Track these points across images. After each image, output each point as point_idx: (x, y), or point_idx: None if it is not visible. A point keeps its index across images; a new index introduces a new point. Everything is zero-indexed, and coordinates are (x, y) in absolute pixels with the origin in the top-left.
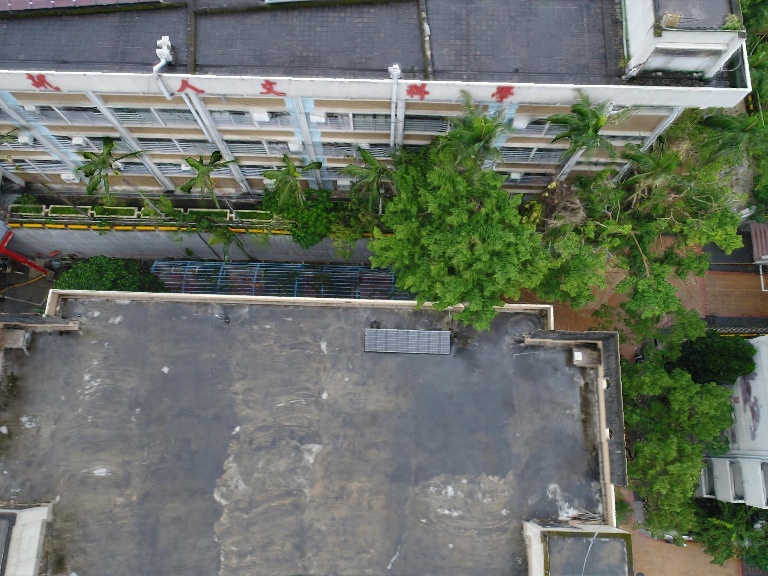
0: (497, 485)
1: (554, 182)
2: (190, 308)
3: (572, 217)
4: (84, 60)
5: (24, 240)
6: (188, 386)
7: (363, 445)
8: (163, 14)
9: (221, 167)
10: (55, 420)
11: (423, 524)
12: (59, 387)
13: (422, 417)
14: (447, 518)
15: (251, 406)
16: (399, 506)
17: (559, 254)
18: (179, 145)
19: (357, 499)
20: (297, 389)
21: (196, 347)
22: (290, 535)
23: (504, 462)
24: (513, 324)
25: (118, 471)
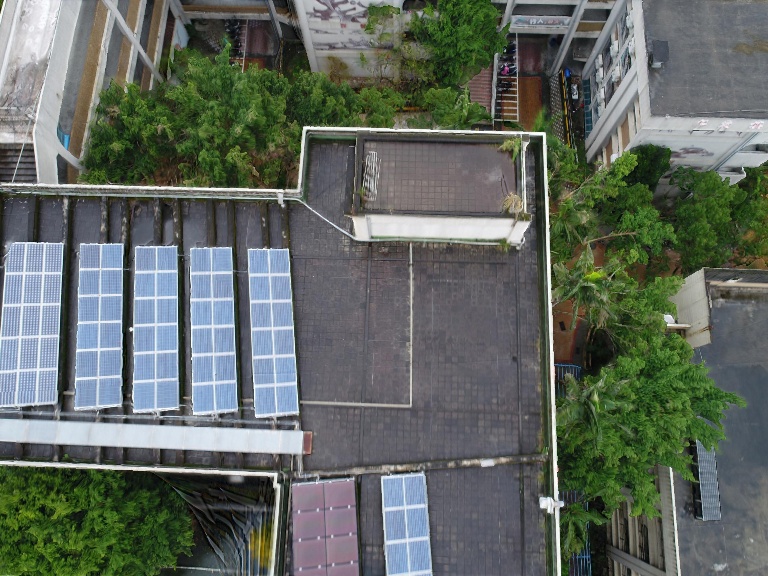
0: None
1: None
2: None
3: None
4: None
5: None
6: None
7: None
8: None
9: None
10: None
11: None
12: None
13: None
14: None
15: None
16: None
17: (653, 320)
18: None
19: None
20: None
21: None
22: None
23: None
24: None
25: None
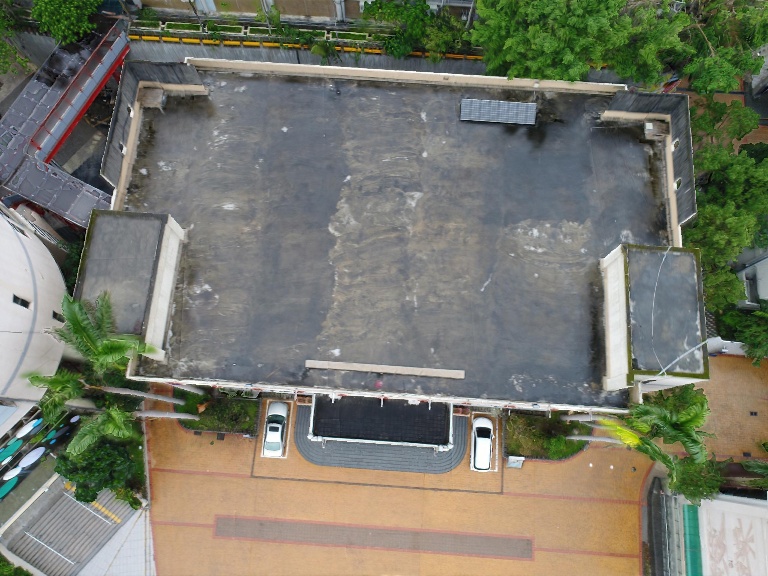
0: (577, 229)
1: None
2: (306, 82)
3: None
4: None
5: None
6: (305, 143)
7: (459, 194)
8: None
9: None
10: (189, 165)
11: (512, 257)
12: (192, 140)
13: (510, 174)
14: (533, 253)
15: (360, 160)
16: (491, 242)
17: (640, 20)
18: None
19: (454, 236)
20: (400, 148)
21: (311, 112)
22: (395, 262)
23: (583, 212)
24: (590, 104)
25: (244, 207)
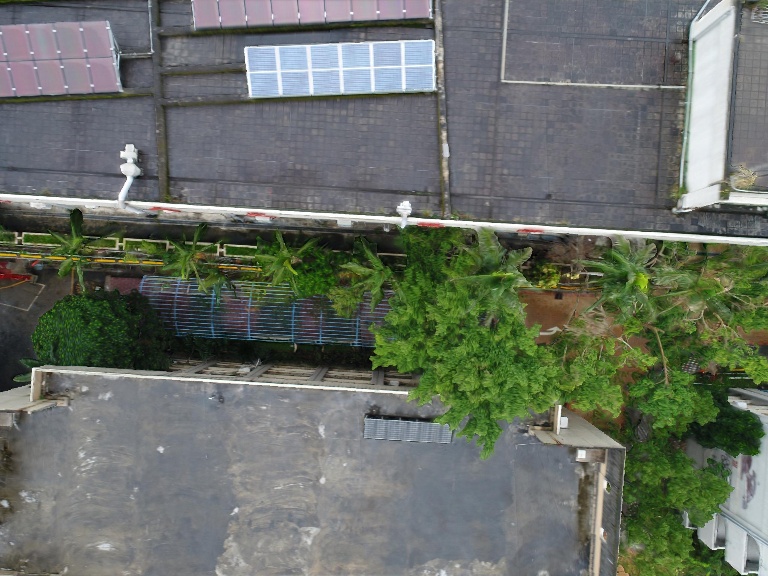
0: (489, 570)
1: (578, 274)
2: (182, 386)
3: (593, 326)
4: (35, 167)
5: None
6: (185, 466)
7: (360, 529)
8: (125, 105)
9: None
10: (54, 496)
11: None
12: (54, 463)
13: (419, 504)
14: None
15: (249, 488)
16: None
17: (574, 377)
18: None
19: None
20: (295, 473)
21: (190, 427)
22: None
23: (497, 549)
24: None
25: (121, 546)
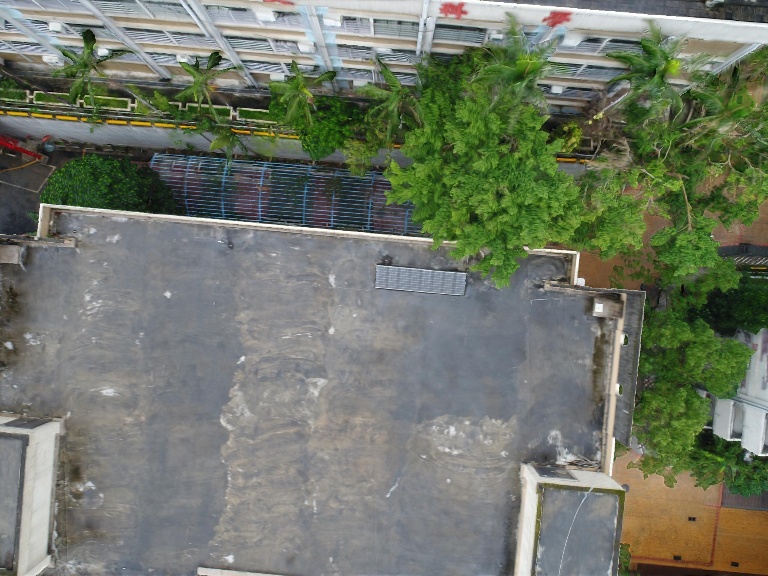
0: (499, 428)
1: (601, 112)
2: (191, 230)
3: (616, 160)
4: None
5: (11, 125)
6: (192, 313)
7: (368, 382)
8: None
9: (222, 60)
10: (59, 339)
11: (423, 460)
12: (60, 306)
13: (430, 358)
14: (447, 456)
15: (256, 337)
16: (401, 442)
17: (595, 207)
18: (172, 37)
19: (360, 433)
20: (303, 322)
21: (199, 272)
22: (294, 461)
23: (509, 407)
24: (534, 267)
25: (125, 392)
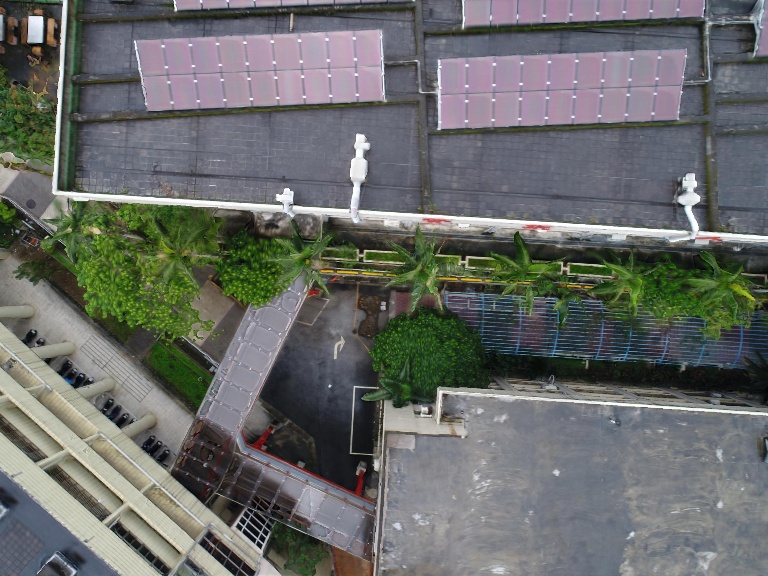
0: None
1: None
2: (579, 408)
3: None
4: (581, 195)
5: None
6: (580, 490)
7: (758, 554)
8: (674, 133)
9: None
10: (448, 519)
11: None
12: (449, 486)
13: None
14: None
15: (645, 512)
16: None
17: None
18: None
19: None
20: (692, 497)
21: (587, 450)
22: None
23: None
24: None
25: (516, 570)
